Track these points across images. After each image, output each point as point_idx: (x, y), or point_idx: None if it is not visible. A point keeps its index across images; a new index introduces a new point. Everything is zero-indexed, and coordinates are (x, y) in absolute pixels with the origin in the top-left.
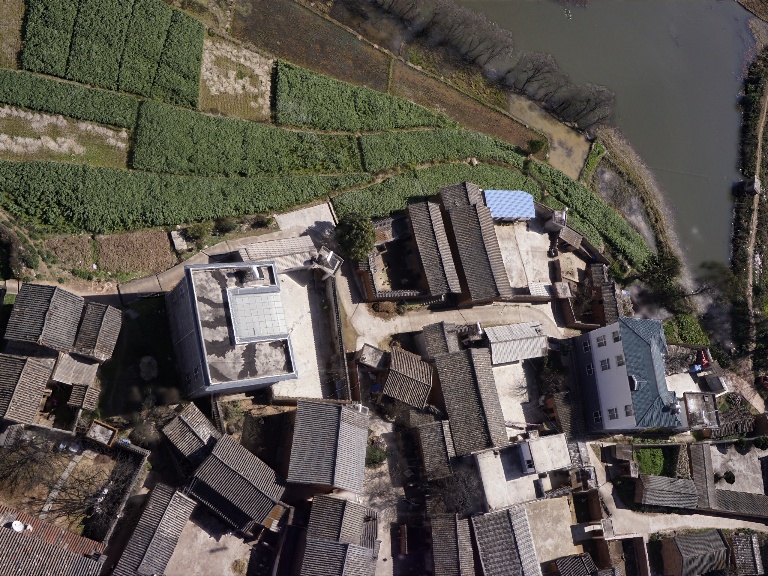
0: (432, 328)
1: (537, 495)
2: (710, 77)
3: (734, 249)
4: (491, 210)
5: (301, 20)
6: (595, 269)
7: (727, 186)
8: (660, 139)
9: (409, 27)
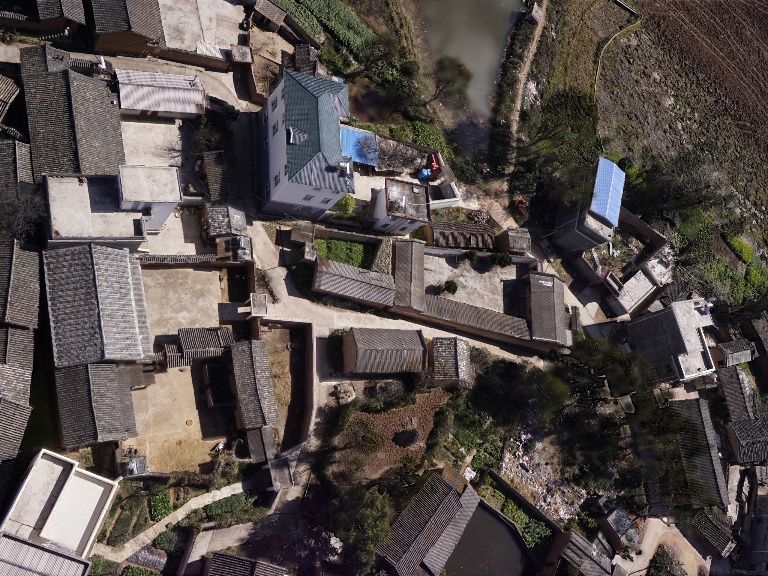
0: (32, 50)
1: (136, 235)
2: None
3: (502, 73)
4: None
5: None
6: (300, 50)
7: (505, 14)
8: None
9: None
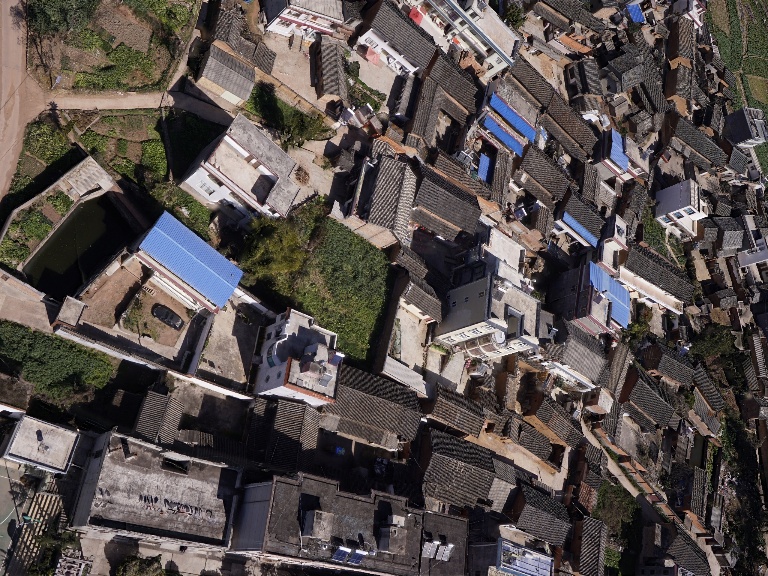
0: None
1: None
2: None
3: None
4: None
5: None
6: None
7: None
8: None
9: None
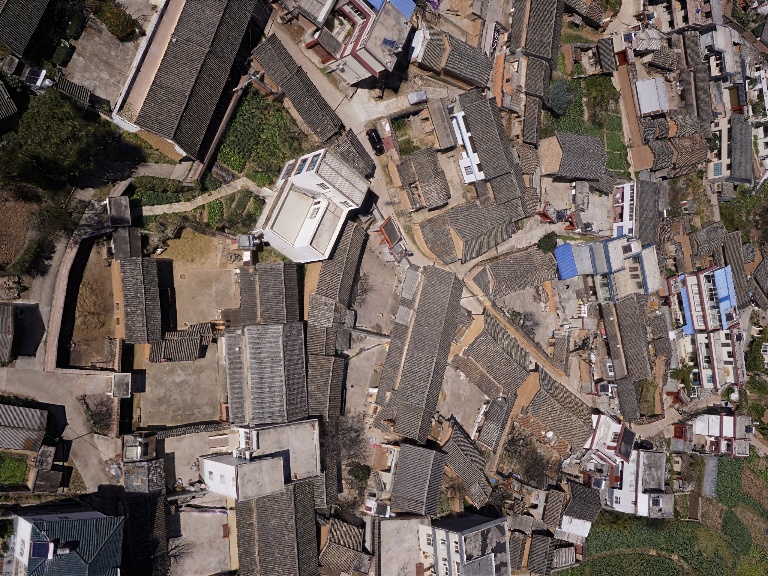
0: None
1: (258, 434)
2: None
3: None
4: None
5: None
6: None
7: None
8: None
9: None
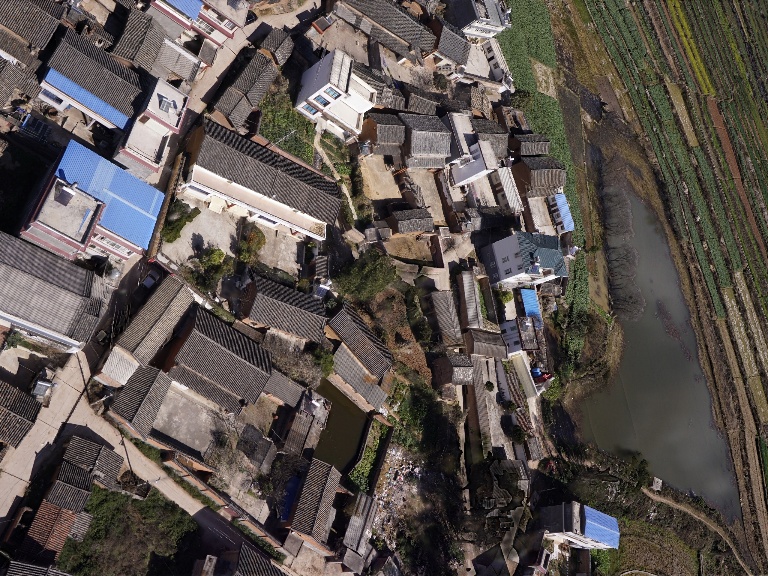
0: None
1: None
2: (689, 459)
3: None
4: (557, 197)
5: (576, 123)
6: None
7: None
8: (636, 387)
9: (601, 188)
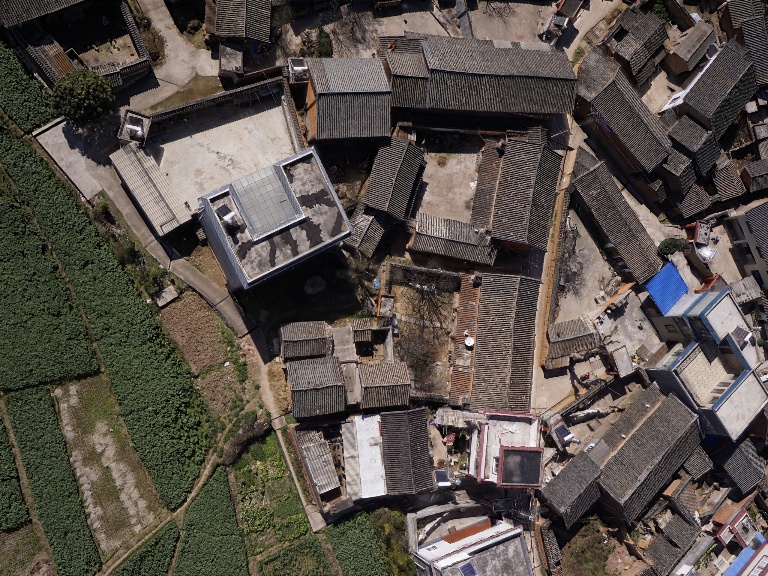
0: None
1: None
2: None
3: None
4: None
5: None
6: None
7: None
8: None
9: None
